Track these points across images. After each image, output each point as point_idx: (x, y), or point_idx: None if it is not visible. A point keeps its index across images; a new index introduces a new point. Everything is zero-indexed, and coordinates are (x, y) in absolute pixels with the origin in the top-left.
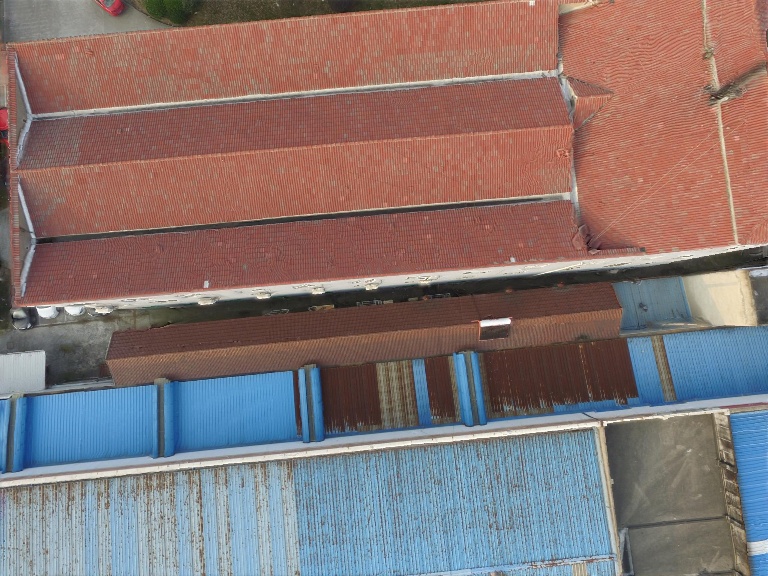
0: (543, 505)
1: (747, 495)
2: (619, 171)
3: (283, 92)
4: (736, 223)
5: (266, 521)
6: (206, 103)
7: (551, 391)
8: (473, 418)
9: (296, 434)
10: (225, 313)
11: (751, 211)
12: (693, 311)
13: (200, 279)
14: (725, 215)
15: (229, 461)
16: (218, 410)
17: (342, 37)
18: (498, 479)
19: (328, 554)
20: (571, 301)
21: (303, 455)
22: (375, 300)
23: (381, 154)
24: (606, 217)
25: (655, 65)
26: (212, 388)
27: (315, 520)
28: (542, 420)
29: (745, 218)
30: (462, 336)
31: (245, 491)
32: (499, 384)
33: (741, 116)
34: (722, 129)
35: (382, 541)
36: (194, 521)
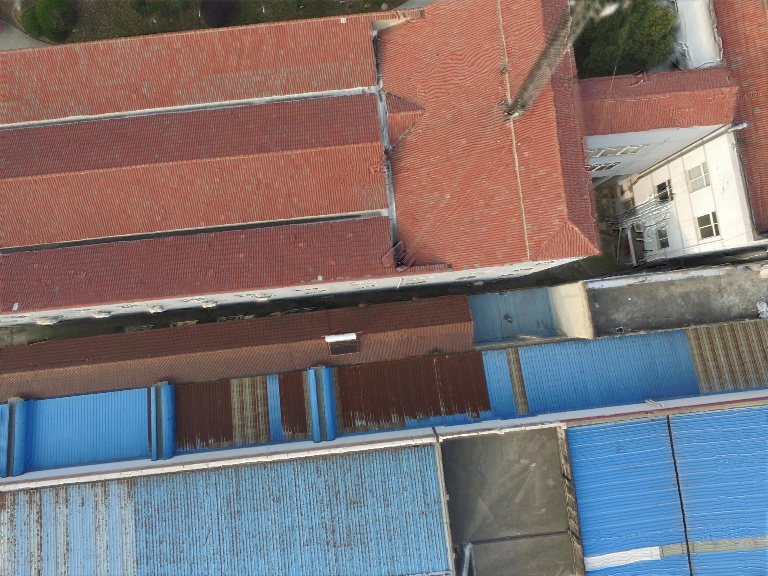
0: (381, 522)
1: (587, 509)
2: (429, 187)
3: (104, 113)
4: (527, 239)
5: (105, 540)
6: (29, 125)
7: (403, 405)
8: (321, 434)
9: (148, 451)
10: (101, 329)
11: (538, 227)
12: (556, 322)
13: (13, 301)
14: (518, 231)
15: (65, 481)
16: (72, 428)
17: (156, 58)
18: (337, 496)
19: (165, 573)
20: (423, 315)
21: (138, 474)
22: (241, 315)
23: (192, 174)
24: (419, 233)
25: (469, 80)
26: (67, 406)
27: (153, 539)
28: (384, 435)
29: (533, 234)
30: (313, 351)
31: (85, 510)
32: (352, 399)
33: (528, 132)
34: (515, 145)
35: (219, 559)
36: (33, 541)
